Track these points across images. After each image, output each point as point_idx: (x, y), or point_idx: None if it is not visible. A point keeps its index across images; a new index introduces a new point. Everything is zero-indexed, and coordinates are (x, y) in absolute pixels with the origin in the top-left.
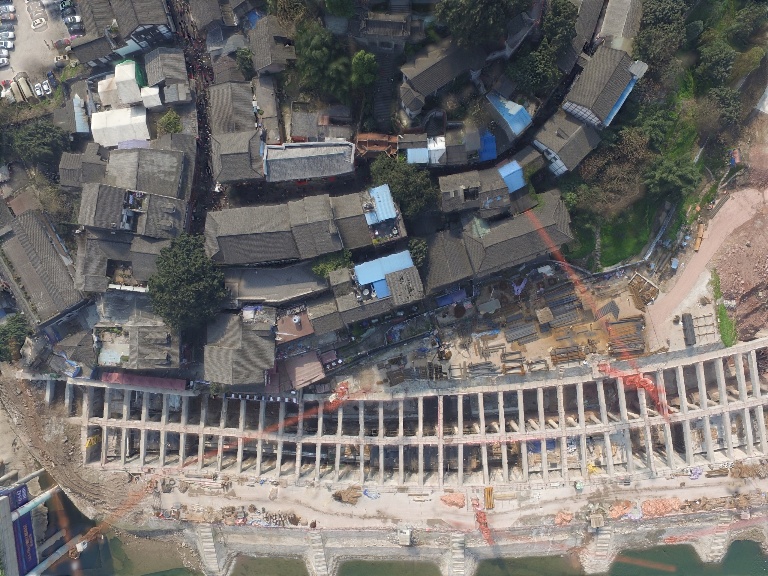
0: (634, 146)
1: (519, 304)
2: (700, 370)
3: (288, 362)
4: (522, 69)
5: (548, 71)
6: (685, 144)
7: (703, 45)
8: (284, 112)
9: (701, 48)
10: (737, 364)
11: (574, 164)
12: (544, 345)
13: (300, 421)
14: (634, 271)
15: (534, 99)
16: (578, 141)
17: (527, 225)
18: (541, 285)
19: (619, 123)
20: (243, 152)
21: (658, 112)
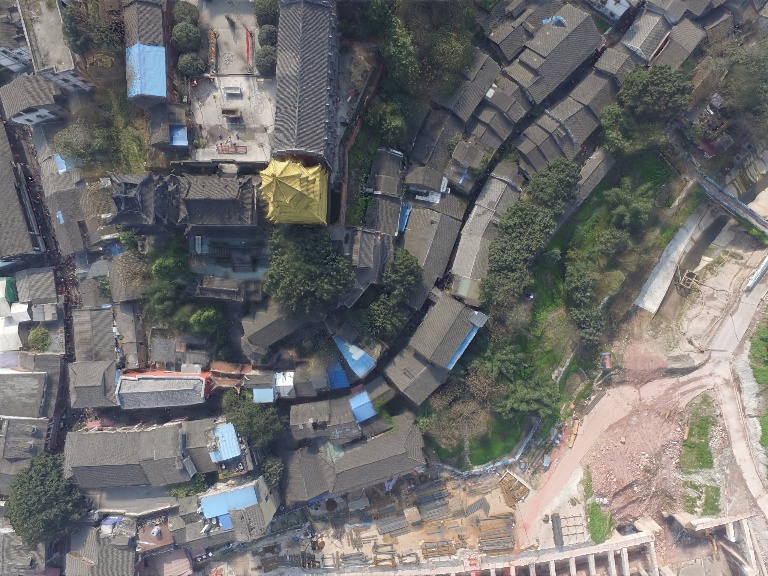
0: (478, 387)
1: (391, 498)
2: (572, 565)
3: (157, 558)
4: (361, 322)
5: (387, 323)
6: (555, 349)
7: (568, 262)
8: (148, 331)
9: (566, 265)
10: (609, 560)
11: (422, 399)
12: (415, 538)
13: None
14: (505, 469)
15: (379, 341)
16: (424, 379)
17: (379, 451)
18: (412, 481)
19: (472, 353)
20: (96, 385)
21: (508, 347)
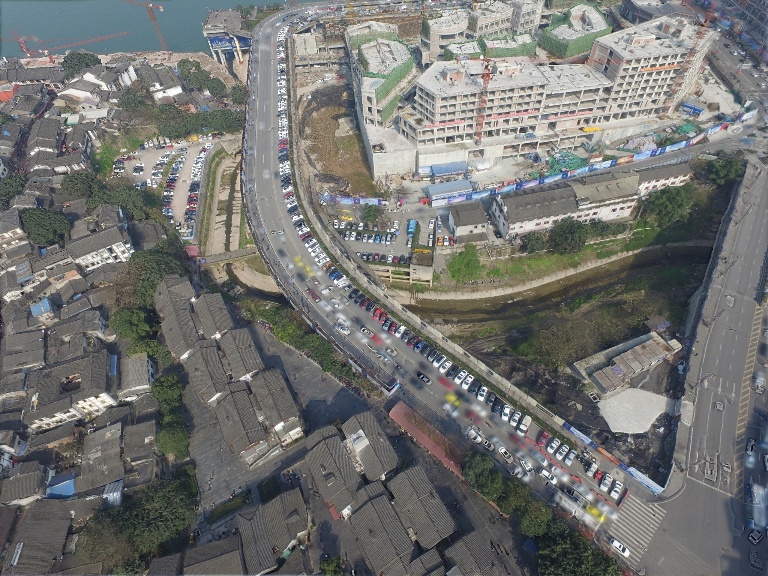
0: None
1: None
2: None
3: None
4: None
5: None
6: None
7: None
8: None
9: None
10: None
11: None
12: None
13: None
14: None
15: None
16: None
17: None
18: None
19: None
20: (22, 86)
21: None
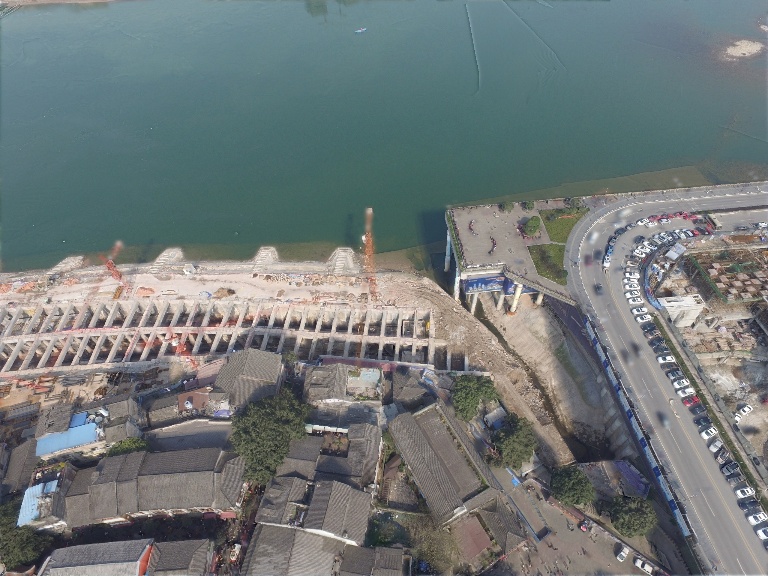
0: None
1: None
2: None
3: None
4: None
5: None
6: None
7: None
8: None
9: None
10: None
11: None
12: (10, 400)
13: (247, 343)
14: None
15: None
16: None
17: None
18: None
19: None
20: (160, 572)
21: None
